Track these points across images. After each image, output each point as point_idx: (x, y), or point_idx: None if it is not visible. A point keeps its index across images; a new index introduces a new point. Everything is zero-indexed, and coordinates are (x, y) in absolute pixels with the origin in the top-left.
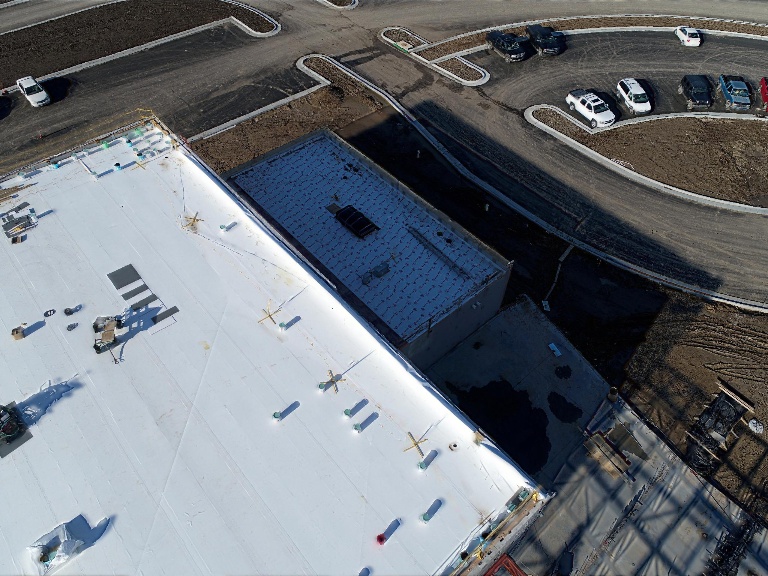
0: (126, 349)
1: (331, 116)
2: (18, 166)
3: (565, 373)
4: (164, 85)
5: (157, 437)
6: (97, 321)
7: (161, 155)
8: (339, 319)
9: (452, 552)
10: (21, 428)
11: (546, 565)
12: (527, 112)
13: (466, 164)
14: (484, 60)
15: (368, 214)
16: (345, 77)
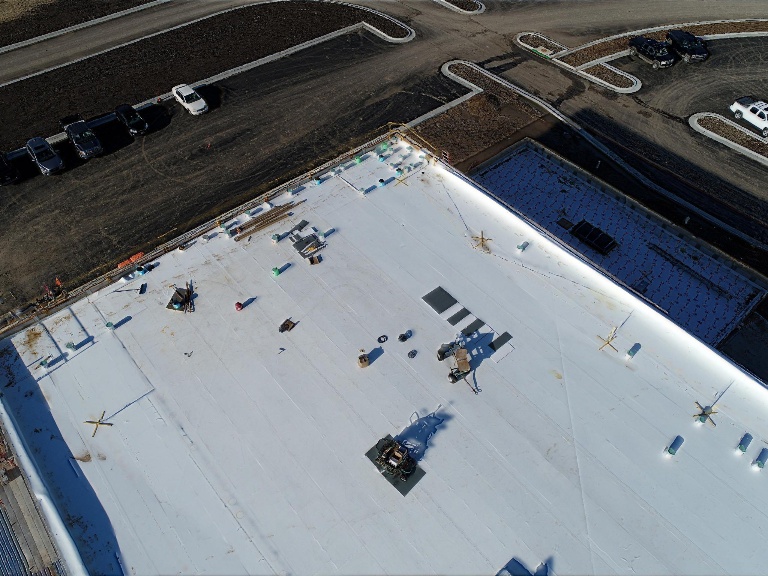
0: (478, 378)
1: (494, 124)
2: (194, 176)
3: None
4: (315, 92)
5: (554, 474)
6: (443, 349)
7: (417, 170)
8: (682, 346)
9: None
10: (413, 464)
11: None
12: (691, 120)
13: (647, 175)
14: (630, 66)
15: (602, 229)
16: (495, 84)
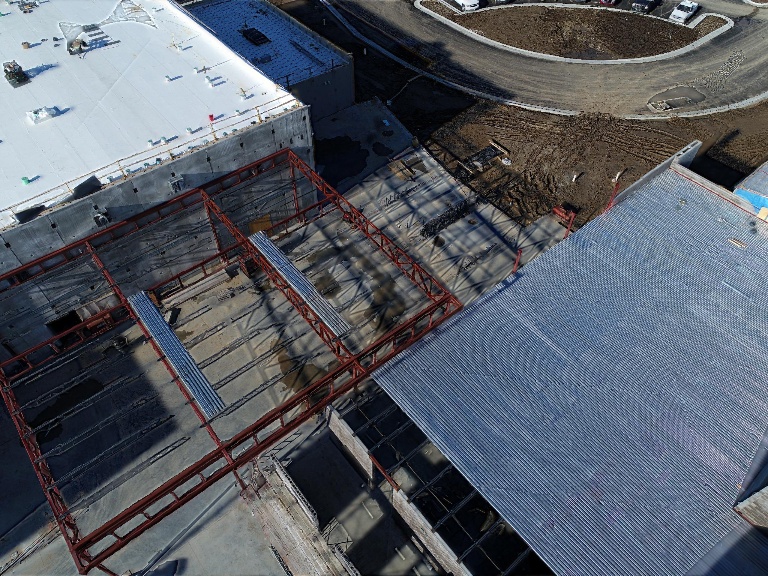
0: (87, 54)
1: None
2: None
3: (389, 134)
4: None
5: (100, 84)
6: None
7: None
8: (215, 47)
9: (249, 125)
10: (25, 77)
11: None
12: (417, 1)
13: (360, 30)
14: None
15: (266, 34)
16: None
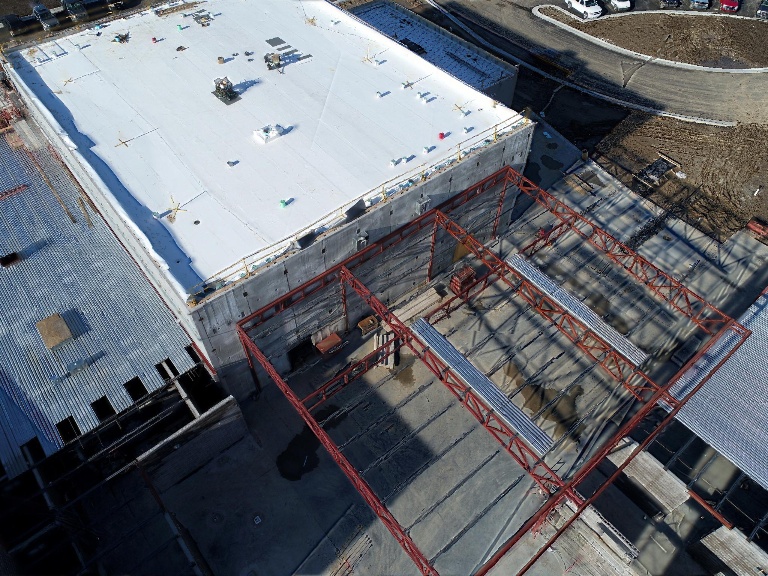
0: (285, 69)
1: None
2: None
3: (553, 146)
4: None
5: (312, 101)
6: (267, 55)
7: None
8: (410, 61)
9: (480, 143)
10: (235, 94)
11: (535, 230)
12: (534, 9)
13: (486, 39)
14: None
15: None
16: None
